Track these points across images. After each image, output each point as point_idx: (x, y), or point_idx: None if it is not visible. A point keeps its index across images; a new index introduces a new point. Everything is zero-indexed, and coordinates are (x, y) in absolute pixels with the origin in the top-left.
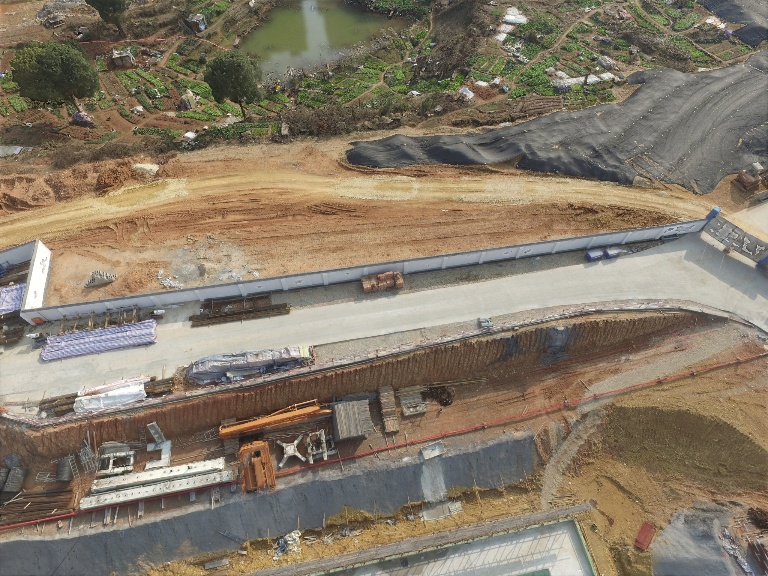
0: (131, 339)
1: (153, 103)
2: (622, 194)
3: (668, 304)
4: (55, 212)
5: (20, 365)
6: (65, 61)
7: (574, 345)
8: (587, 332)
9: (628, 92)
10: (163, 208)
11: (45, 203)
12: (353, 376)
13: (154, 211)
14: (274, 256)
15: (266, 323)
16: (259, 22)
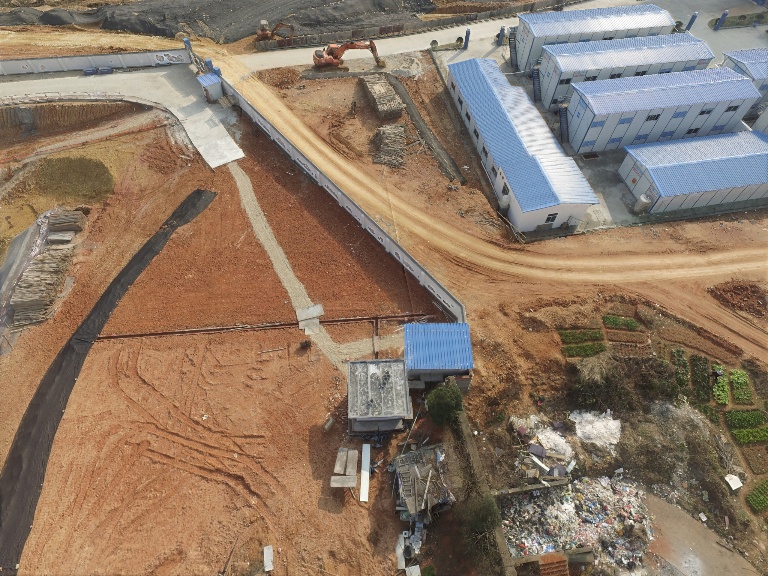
0: None
1: None
2: (162, 43)
3: (115, 97)
4: None
5: None
6: None
7: (41, 123)
8: (48, 113)
9: None
10: None
11: None
12: None
13: None
14: None
15: None
16: None
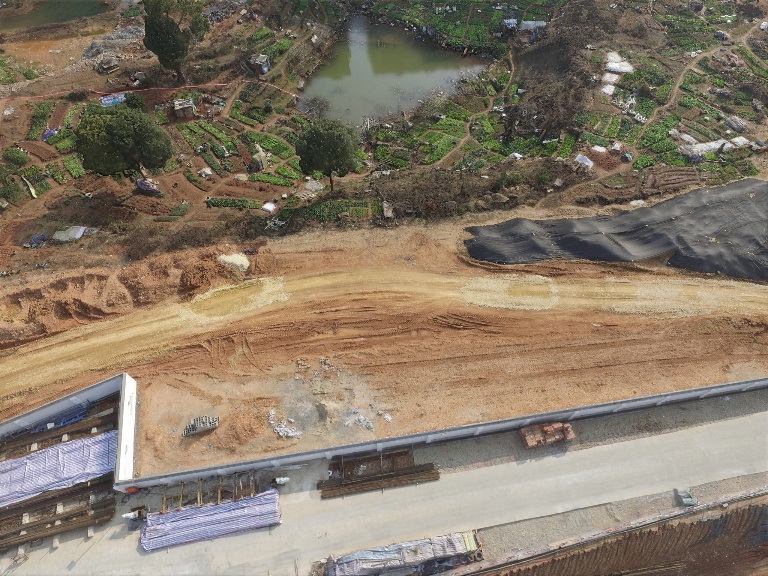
0: (251, 520)
1: (222, 163)
2: None
3: None
4: (135, 323)
5: (116, 556)
6: (138, 131)
7: None
8: None
9: None
10: (262, 319)
11: (122, 310)
12: (531, 573)
13: (252, 323)
14: (406, 391)
15: (413, 494)
16: (322, 60)
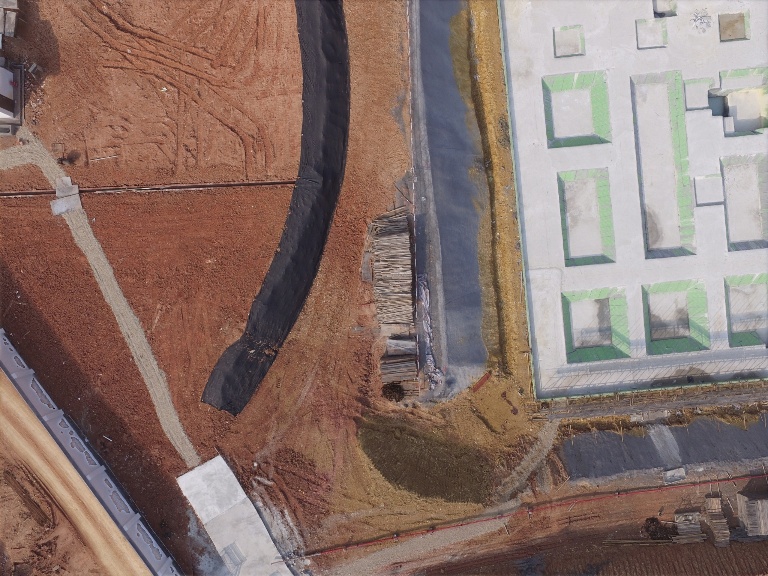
0: None
1: None
2: None
3: None
4: None
5: None
6: None
7: None
8: None
9: None
10: None
11: None
12: None
13: None
14: None
15: None
16: None
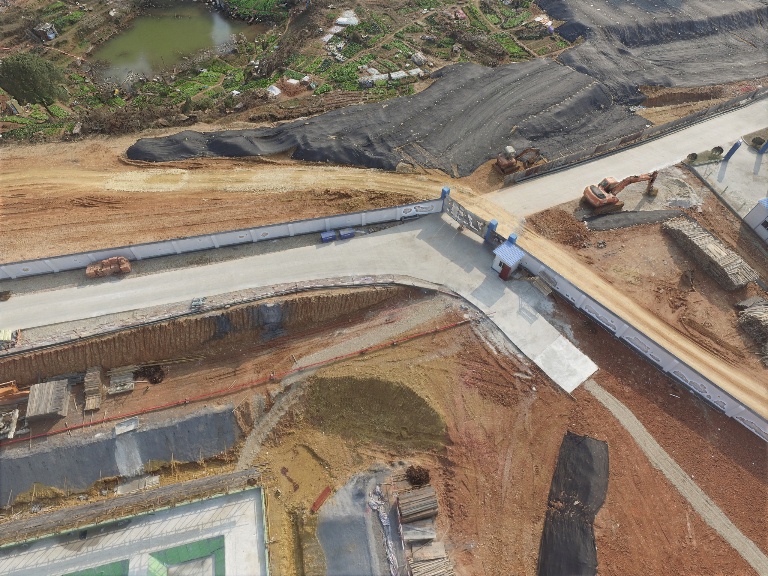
0: None
1: None
2: (383, 180)
3: (383, 279)
4: None
5: None
6: None
7: (290, 321)
8: (300, 308)
9: (427, 86)
10: None
11: None
12: (55, 357)
13: None
14: (16, 247)
15: None
16: (119, 30)
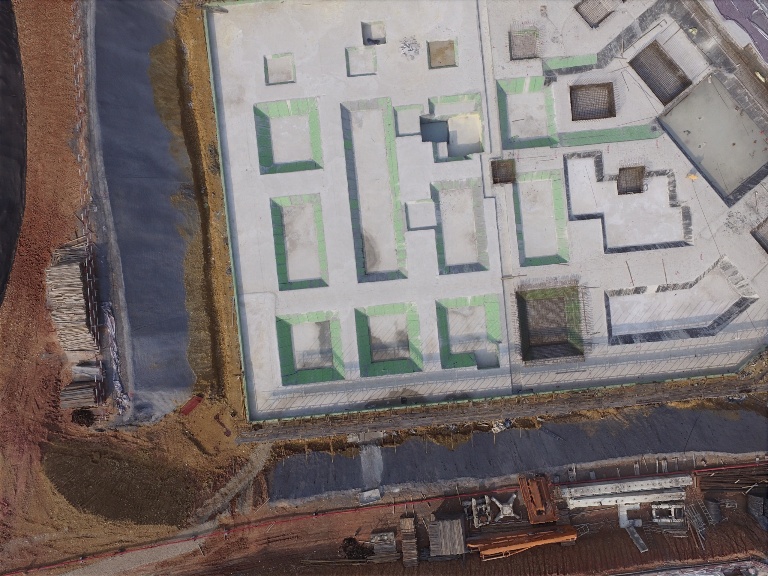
0: None
1: None
2: None
3: None
4: None
5: None
6: None
7: None
8: None
9: None
10: None
11: None
12: None
13: None
14: None
15: None
16: None
